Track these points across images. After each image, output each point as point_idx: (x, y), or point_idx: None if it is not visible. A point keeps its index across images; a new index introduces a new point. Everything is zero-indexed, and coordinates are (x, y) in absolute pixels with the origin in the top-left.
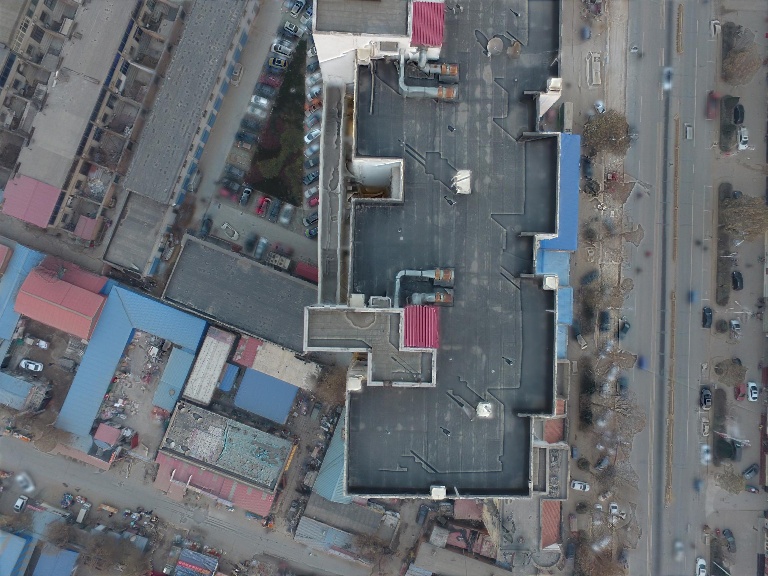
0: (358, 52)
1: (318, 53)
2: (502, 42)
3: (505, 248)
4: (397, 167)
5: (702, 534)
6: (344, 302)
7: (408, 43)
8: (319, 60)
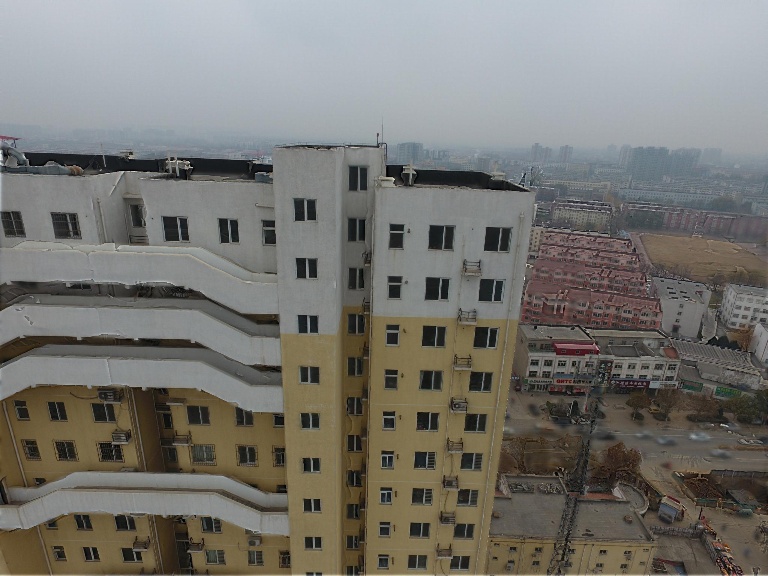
0: None
1: None
2: (56, 163)
3: None
4: (126, 193)
5: (551, 421)
6: None
7: None
8: None
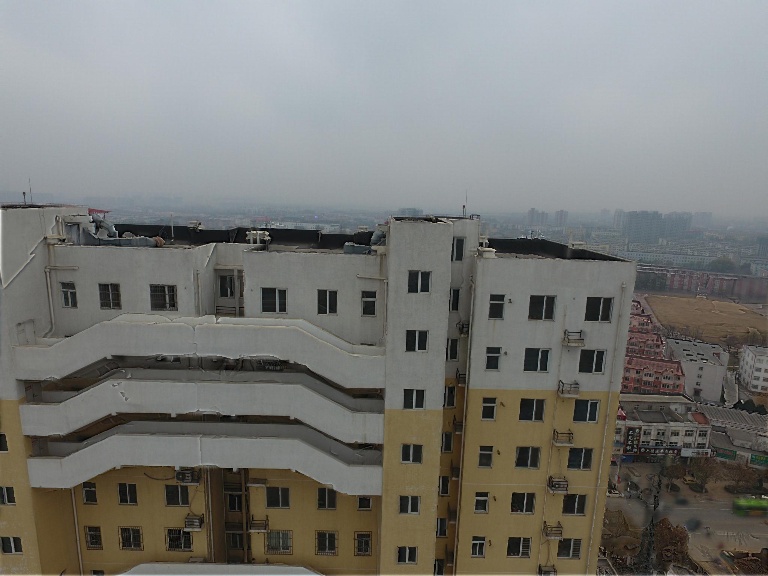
0: (49, 239)
1: (0, 261)
2: (132, 234)
3: (329, 249)
4: (216, 264)
5: None
6: (382, 345)
7: None
8: (3, 281)
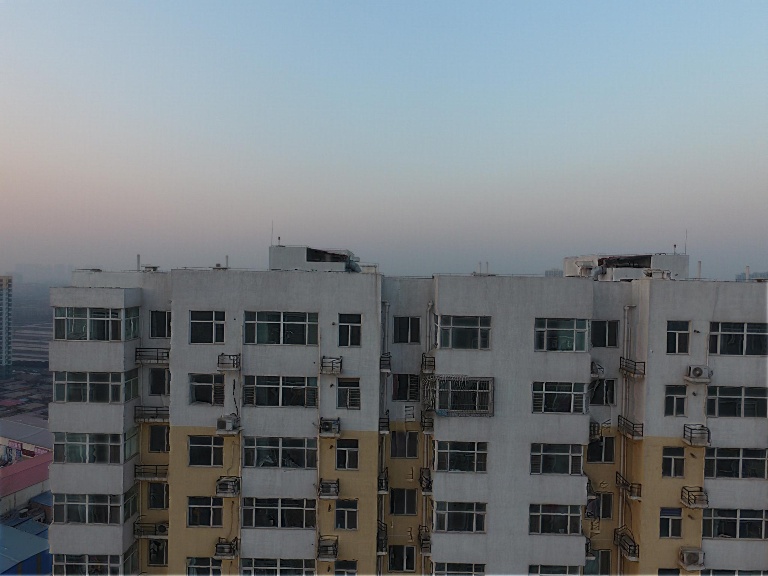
0: None
1: None
2: None
3: None
4: None
5: None
6: None
7: (597, 262)
8: None
